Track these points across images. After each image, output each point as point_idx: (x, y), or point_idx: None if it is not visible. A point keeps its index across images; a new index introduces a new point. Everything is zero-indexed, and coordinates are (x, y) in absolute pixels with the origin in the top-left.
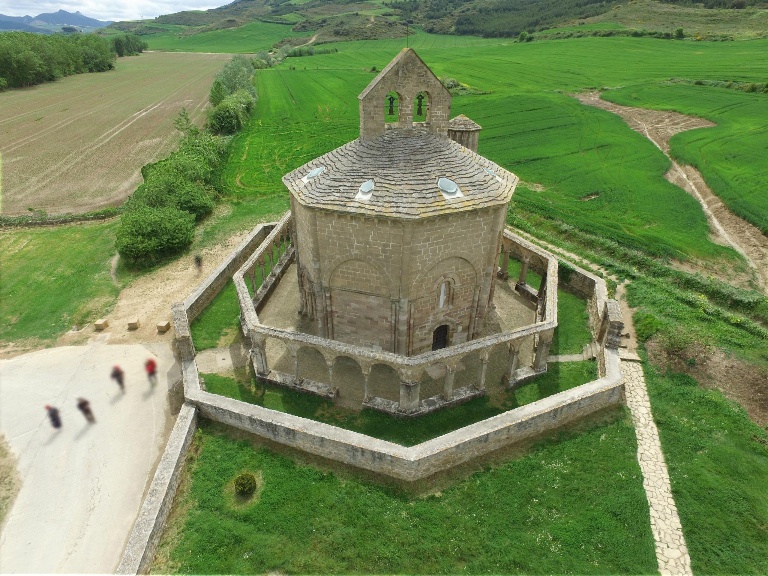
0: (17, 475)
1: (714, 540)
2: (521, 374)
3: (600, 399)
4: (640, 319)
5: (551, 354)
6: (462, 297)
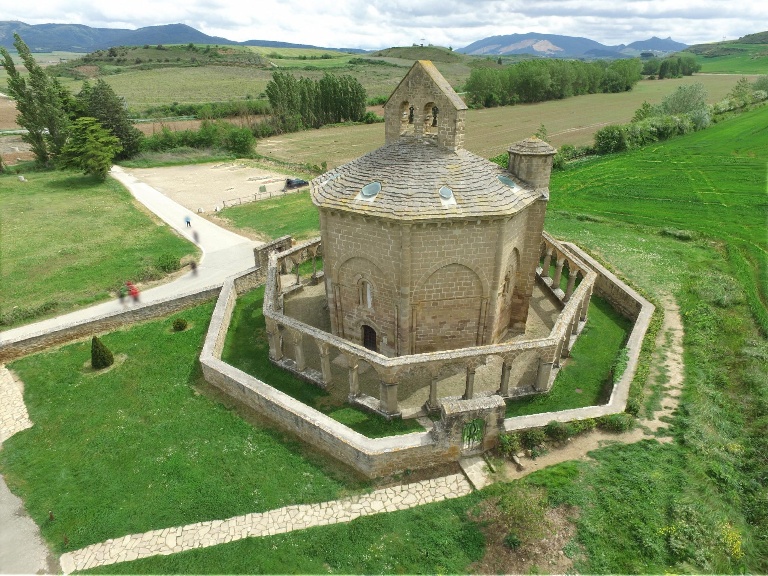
0: (178, 278)
1: (190, 573)
2: (366, 400)
3: (345, 450)
4: (559, 465)
5: (433, 419)
6: (383, 307)
